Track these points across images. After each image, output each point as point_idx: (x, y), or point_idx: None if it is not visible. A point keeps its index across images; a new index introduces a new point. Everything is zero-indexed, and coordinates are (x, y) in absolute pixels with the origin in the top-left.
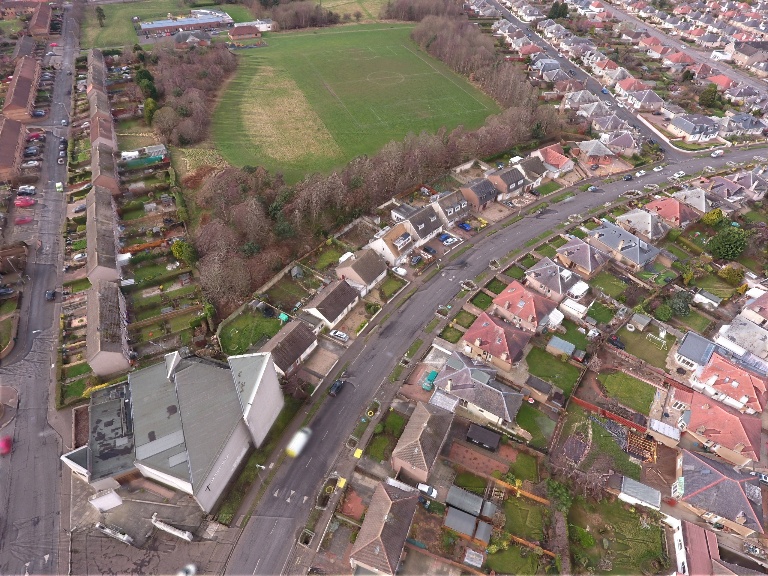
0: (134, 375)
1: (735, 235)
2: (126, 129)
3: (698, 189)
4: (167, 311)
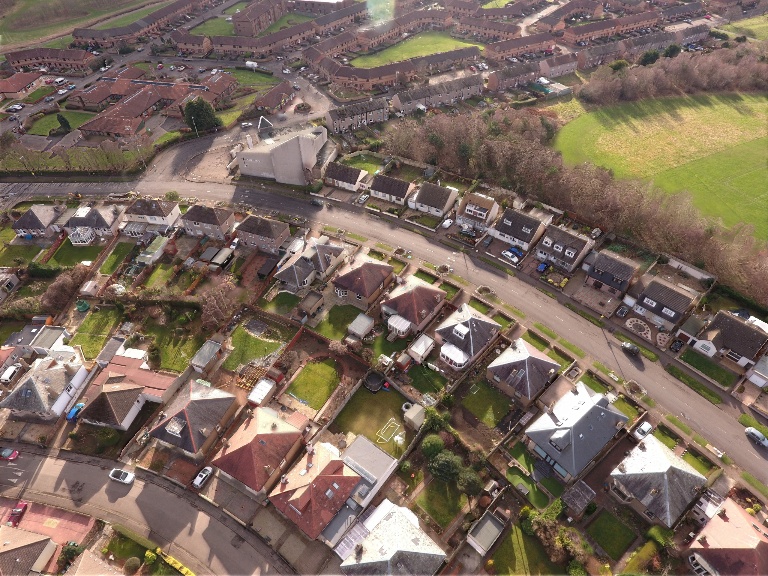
0: None
1: None
2: (586, 73)
3: None
4: (375, 131)
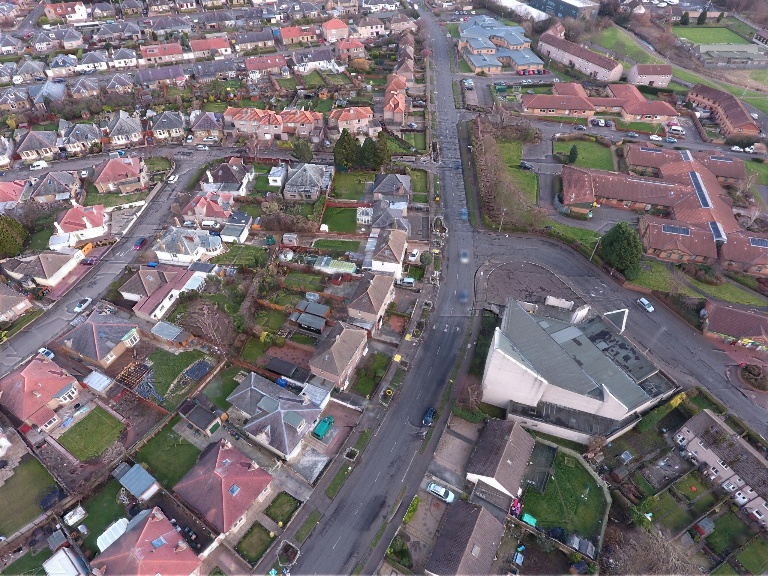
0: (646, 398)
1: None
2: None
3: None
4: (704, 522)
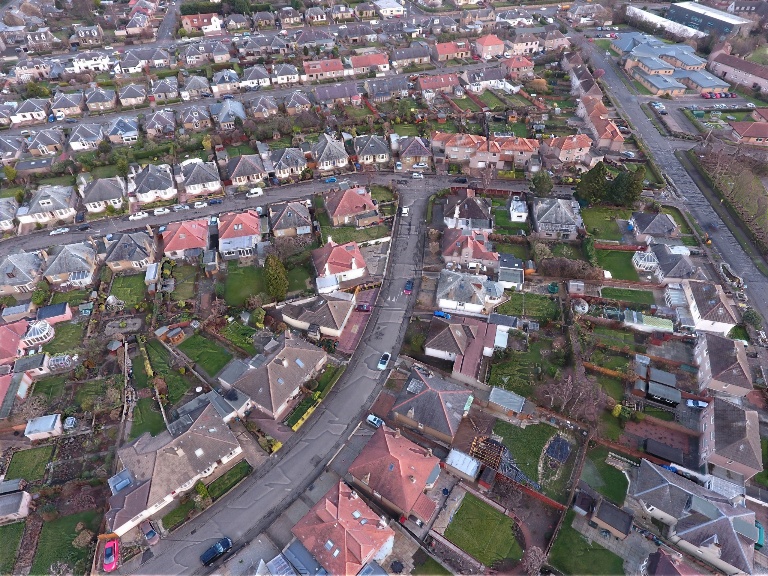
0: None
1: None
2: None
3: None
4: None
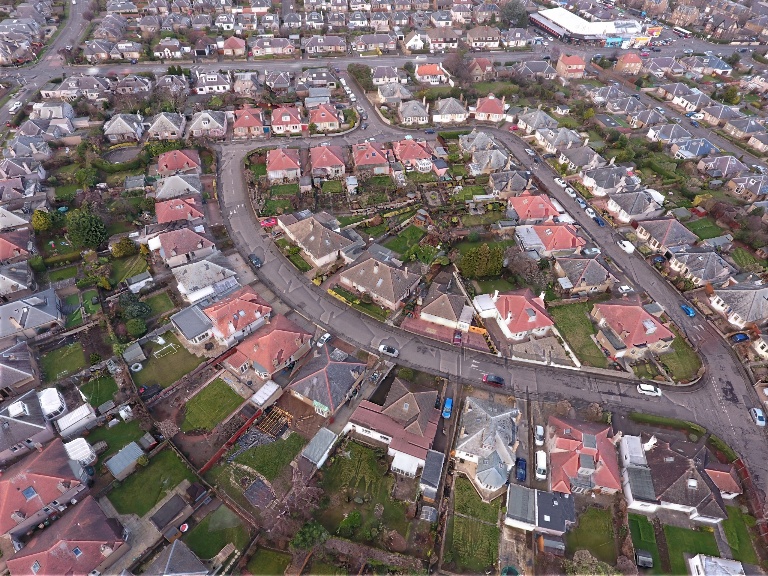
0: None
1: (83, 220)
2: None
3: None
4: None
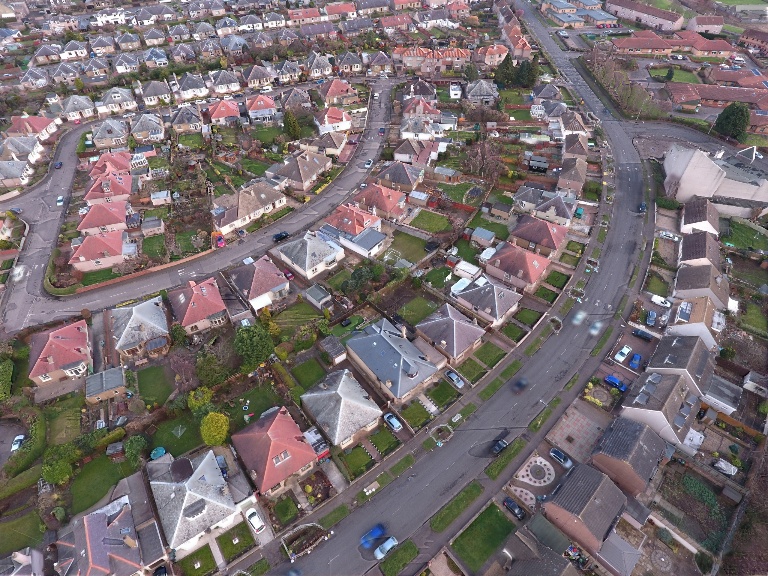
0: None
1: (254, 328)
2: None
3: (192, 494)
4: None
